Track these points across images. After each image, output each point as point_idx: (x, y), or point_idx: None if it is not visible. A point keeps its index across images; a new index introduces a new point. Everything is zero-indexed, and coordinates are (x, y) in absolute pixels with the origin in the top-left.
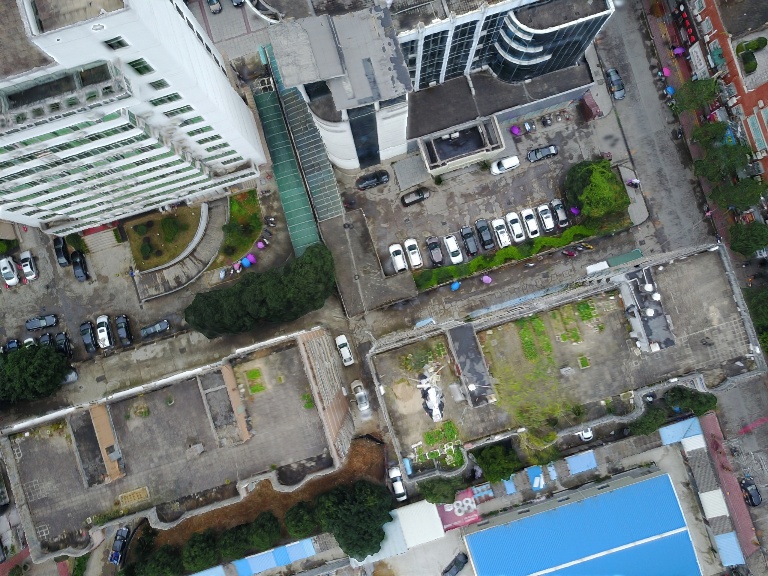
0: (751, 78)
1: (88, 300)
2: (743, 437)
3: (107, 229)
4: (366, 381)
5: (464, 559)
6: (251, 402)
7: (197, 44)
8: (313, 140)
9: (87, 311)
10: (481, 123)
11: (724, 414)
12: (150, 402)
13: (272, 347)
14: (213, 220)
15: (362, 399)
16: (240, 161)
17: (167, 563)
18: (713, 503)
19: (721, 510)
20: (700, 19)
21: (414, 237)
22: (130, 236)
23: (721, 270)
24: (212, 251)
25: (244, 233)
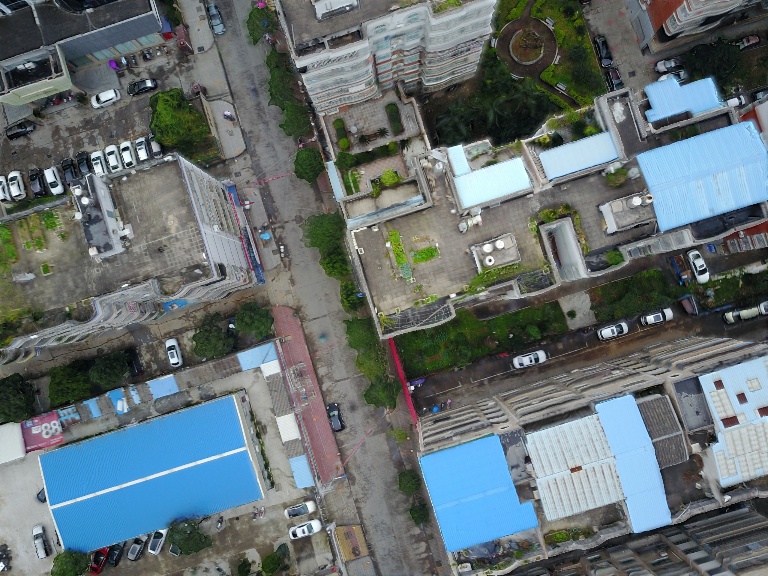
0: None
1: None
2: (332, 365)
3: None
4: None
5: None
6: None
7: None
8: None
9: None
10: (48, 52)
11: (314, 342)
12: None
13: None
14: None
15: None
16: None
17: None
18: (288, 427)
19: (295, 433)
20: None
21: (20, 169)
22: None
23: (181, 180)
24: None
25: None
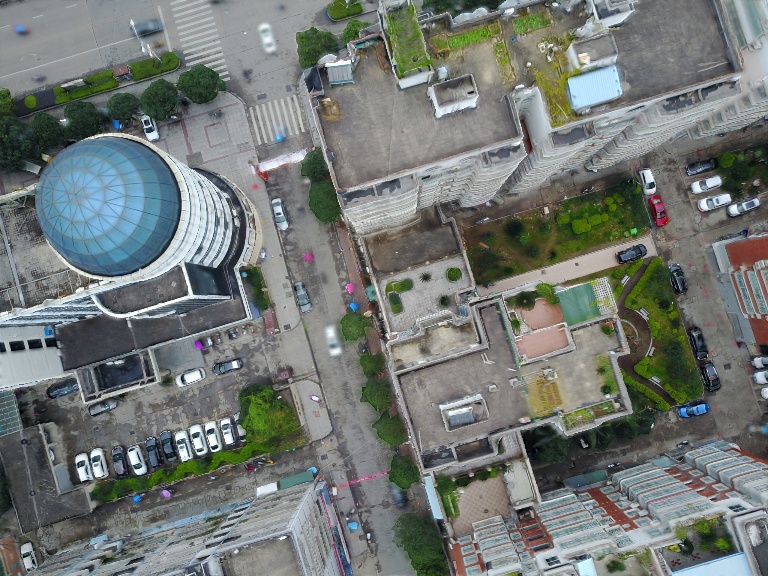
0: (400, 317)
1: None
2: None
3: None
4: None
5: None
6: None
7: None
8: None
9: None
10: (139, 354)
11: None
12: None
13: None
14: None
15: None
16: None
17: None
18: None
19: None
20: (362, 250)
21: (102, 446)
22: None
23: (294, 556)
24: None
25: None
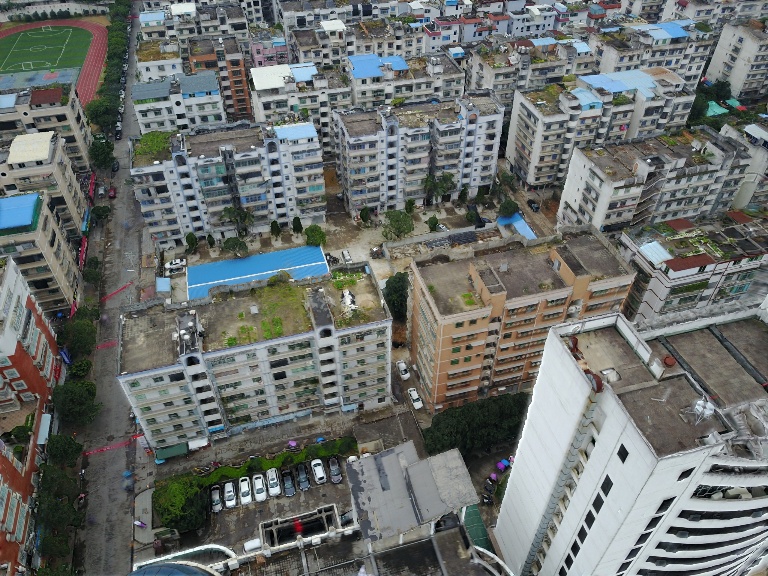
0: None
1: None
2: None
3: None
4: (398, 380)
5: None
6: None
7: (544, 489)
8: None
9: None
10: None
11: None
12: (540, 291)
13: None
14: None
15: (401, 366)
16: None
17: None
18: None
19: None
20: None
21: None
22: None
23: (124, 365)
24: None
25: None
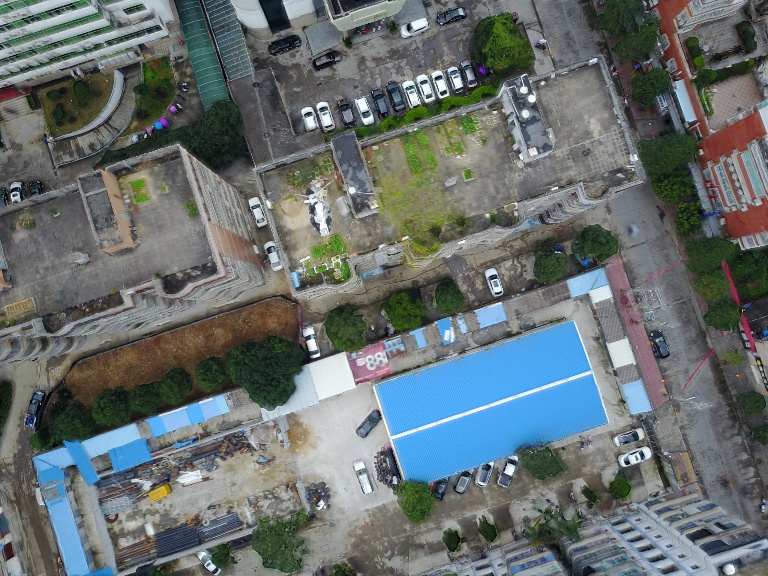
0: None
1: (3, 168)
2: None
3: (20, 95)
4: None
5: (378, 416)
6: (136, 212)
7: None
8: (222, 1)
9: (2, 179)
10: None
11: (633, 270)
12: (36, 215)
13: (157, 159)
14: (129, 90)
15: (275, 259)
16: (144, 12)
17: (77, 416)
18: (620, 352)
19: (628, 359)
20: None
21: (326, 101)
22: (44, 104)
23: (601, 84)
24: (127, 119)
25: (156, 97)
